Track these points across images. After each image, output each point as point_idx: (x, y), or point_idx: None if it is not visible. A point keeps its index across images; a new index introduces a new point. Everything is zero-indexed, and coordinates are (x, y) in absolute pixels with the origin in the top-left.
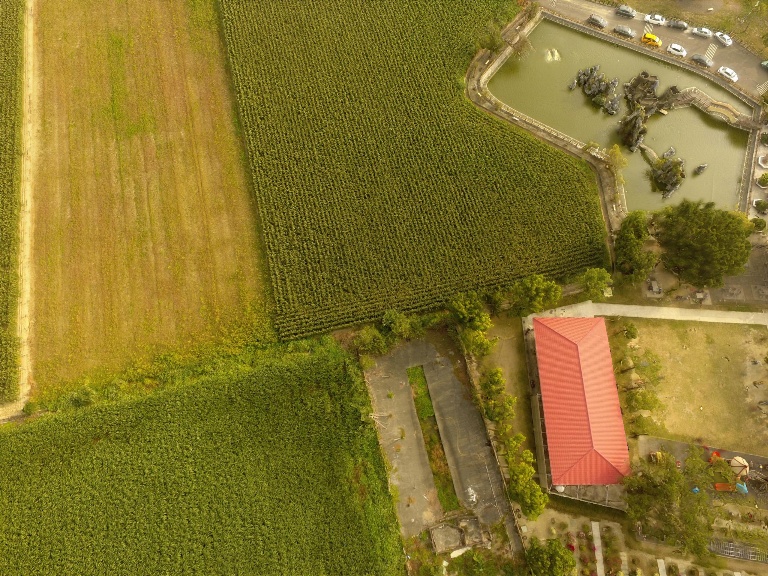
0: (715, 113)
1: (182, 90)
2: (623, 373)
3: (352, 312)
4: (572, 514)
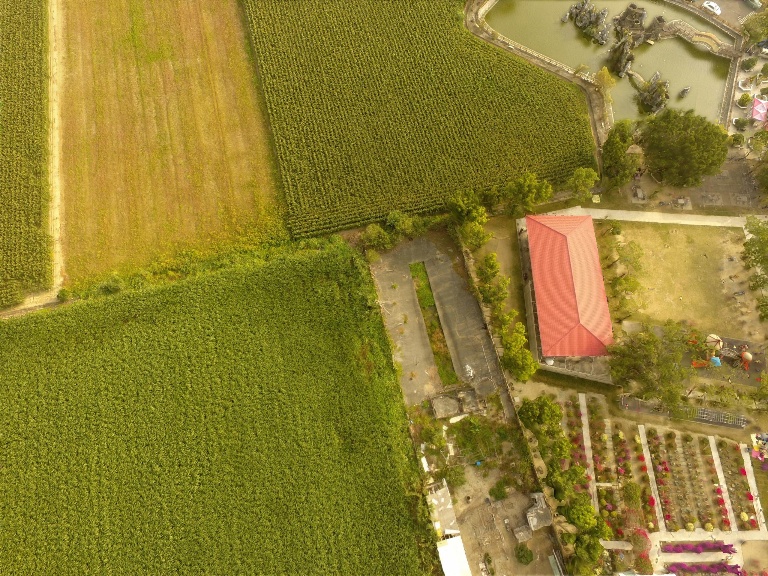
0: (699, 42)
1: (197, 22)
2: (609, 268)
3: (359, 213)
4: (561, 387)
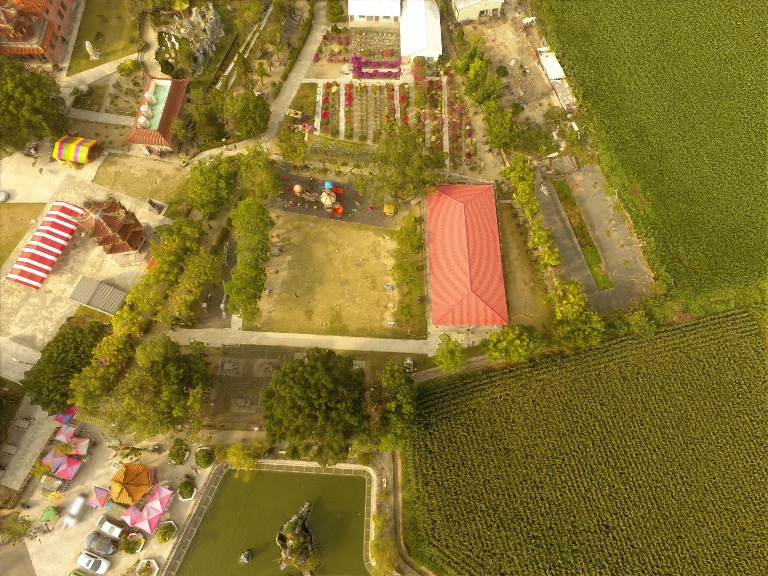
0: None
1: None
2: None
3: (687, 336)
4: None
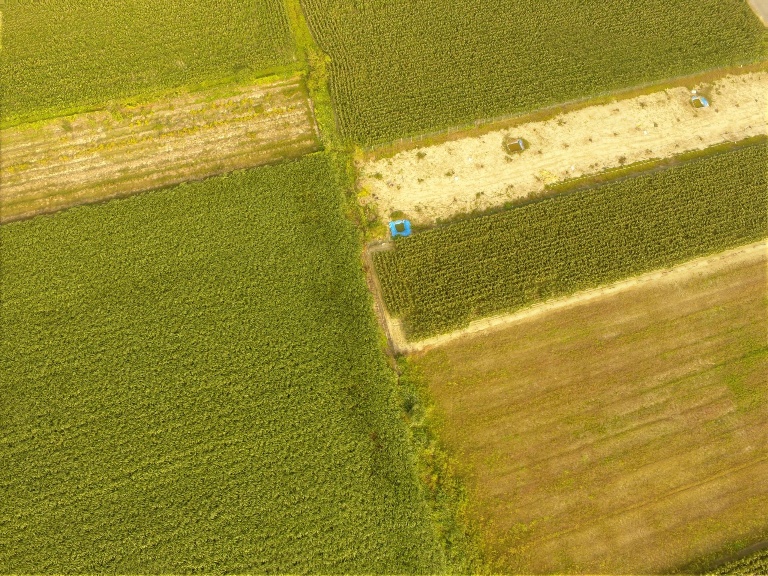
0: None
1: None
2: None
3: None
4: None
